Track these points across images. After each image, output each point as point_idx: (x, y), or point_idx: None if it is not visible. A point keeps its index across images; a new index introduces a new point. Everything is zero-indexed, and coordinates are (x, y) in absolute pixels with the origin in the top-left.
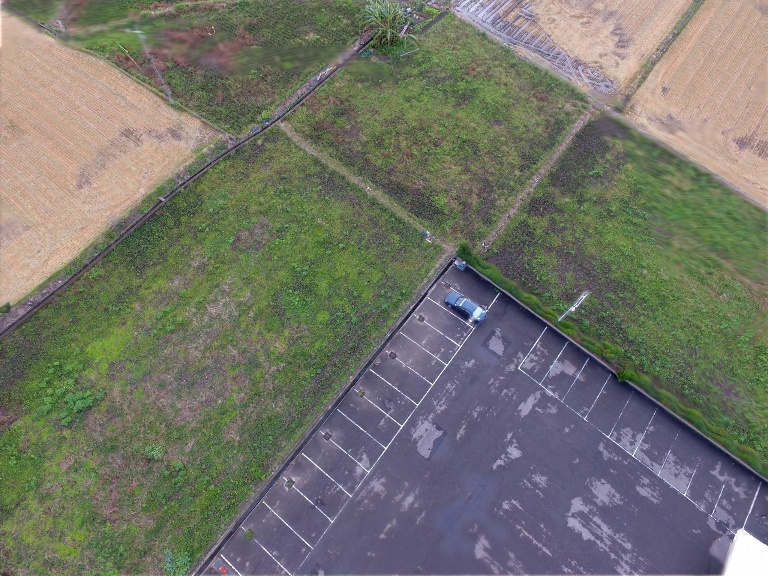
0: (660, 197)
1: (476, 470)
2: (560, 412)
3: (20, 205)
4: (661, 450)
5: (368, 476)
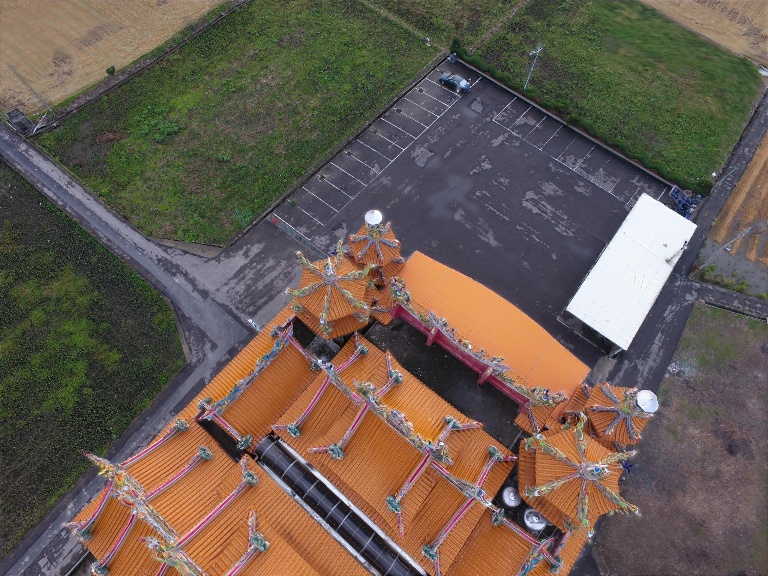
0: (612, 23)
1: (458, 174)
2: (522, 145)
3: (114, 14)
4: (595, 168)
5: (379, 176)
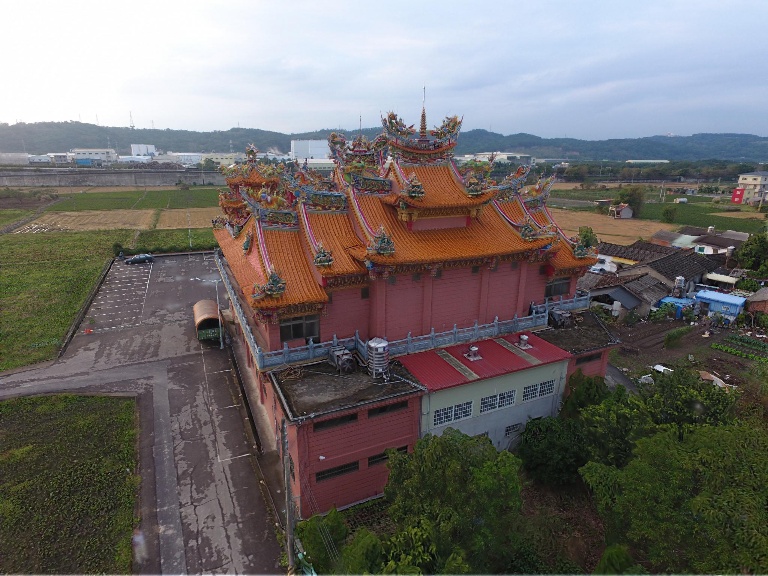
0: None
1: None
2: None
3: None
4: None
5: None
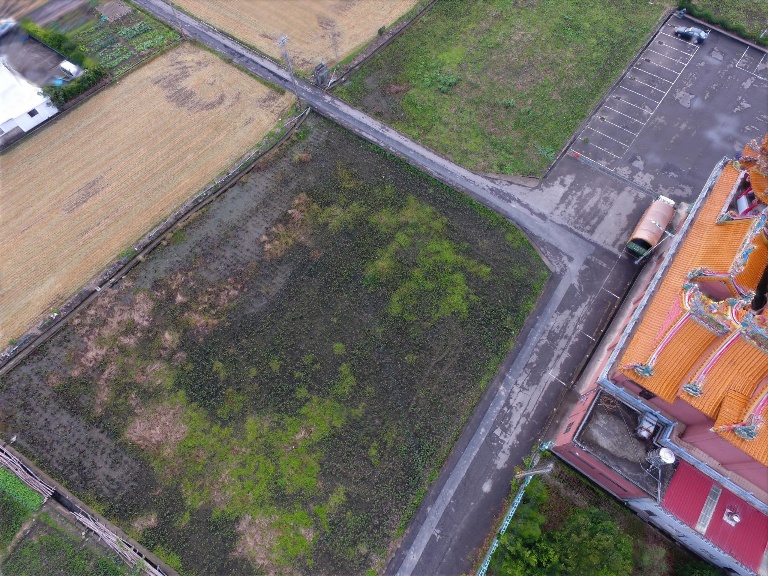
0: None
1: (723, 113)
2: None
3: None
4: None
5: (652, 116)
